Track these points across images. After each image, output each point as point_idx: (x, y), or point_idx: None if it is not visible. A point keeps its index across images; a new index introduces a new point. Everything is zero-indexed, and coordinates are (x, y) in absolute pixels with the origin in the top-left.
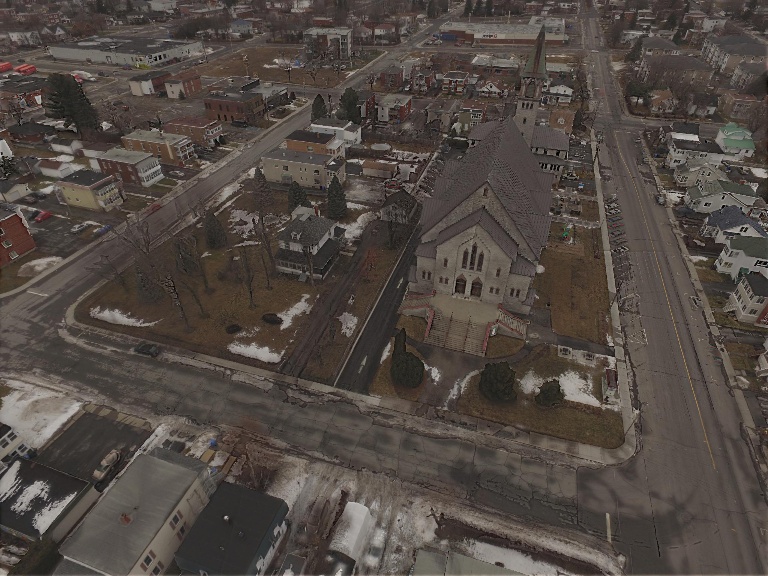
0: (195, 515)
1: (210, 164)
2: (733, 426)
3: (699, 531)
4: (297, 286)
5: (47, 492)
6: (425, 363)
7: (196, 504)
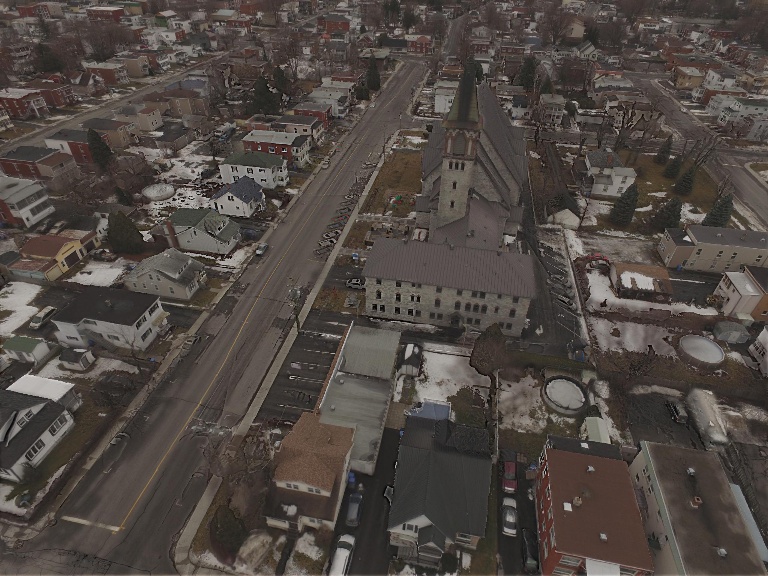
0: None
1: None
2: None
3: (385, 120)
4: None
5: None
6: None
7: None
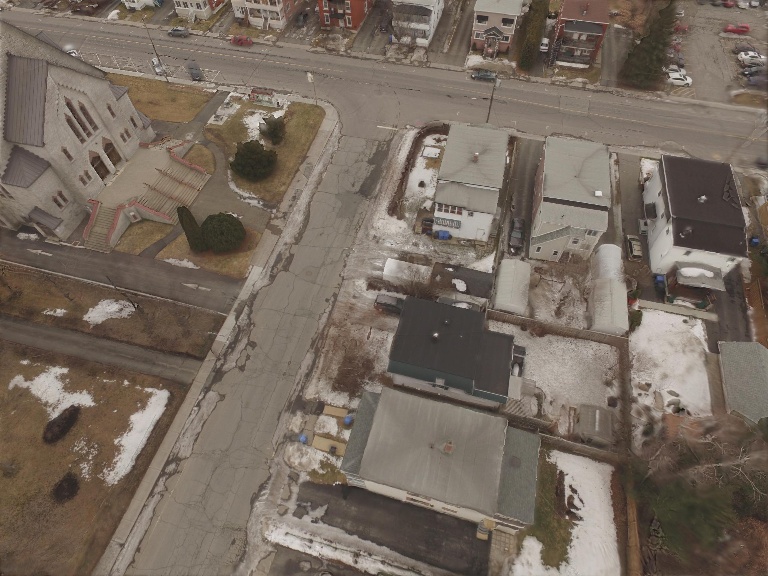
0: None
1: None
2: (309, 55)
3: (387, 90)
4: None
5: None
6: None
7: None
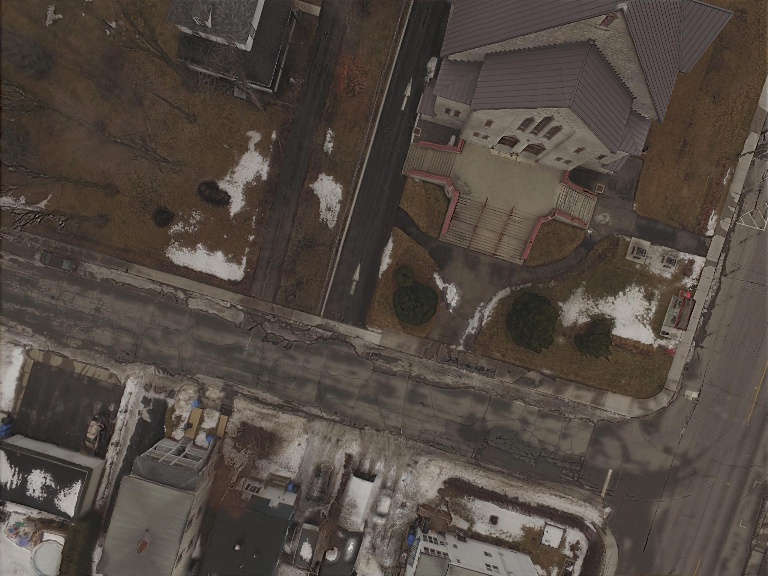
0: (206, 493)
1: None
2: None
3: (694, 486)
4: (235, 111)
5: (51, 480)
6: (439, 277)
7: (203, 492)
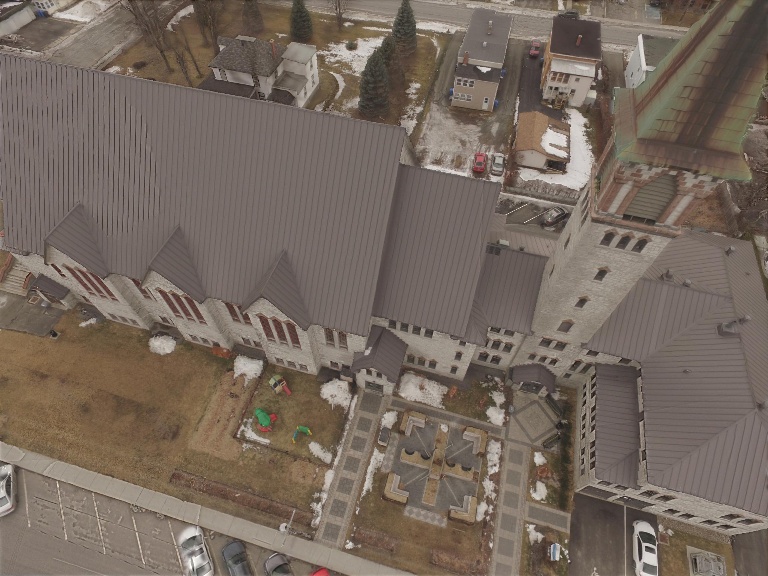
0: None
1: (507, 3)
2: None
3: None
4: None
5: None
6: None
7: None
